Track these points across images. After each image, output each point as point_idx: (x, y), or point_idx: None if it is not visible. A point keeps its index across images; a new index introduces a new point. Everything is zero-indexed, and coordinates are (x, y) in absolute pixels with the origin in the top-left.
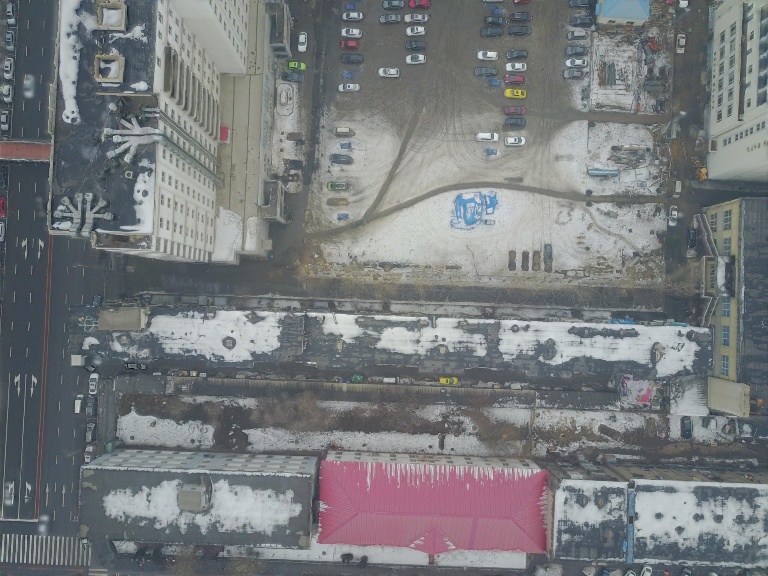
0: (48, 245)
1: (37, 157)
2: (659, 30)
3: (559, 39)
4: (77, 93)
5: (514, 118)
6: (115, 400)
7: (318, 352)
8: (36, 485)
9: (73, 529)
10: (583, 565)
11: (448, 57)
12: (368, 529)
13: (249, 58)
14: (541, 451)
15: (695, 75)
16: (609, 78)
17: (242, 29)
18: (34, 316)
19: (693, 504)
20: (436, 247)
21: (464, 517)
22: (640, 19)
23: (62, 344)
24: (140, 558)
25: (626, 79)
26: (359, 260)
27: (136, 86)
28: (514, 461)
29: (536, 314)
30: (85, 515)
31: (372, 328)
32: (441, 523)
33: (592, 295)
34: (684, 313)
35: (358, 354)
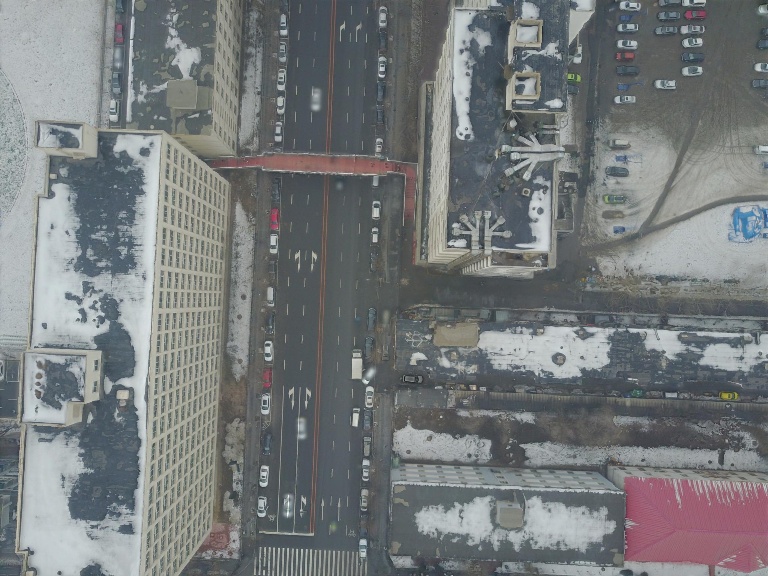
0: (321, 257)
1: (322, 169)
2: None
3: None
4: (470, 109)
5: None
6: (391, 414)
7: (640, 368)
8: (311, 499)
9: (349, 543)
10: None
11: (724, 69)
12: (680, 547)
13: None
14: None
15: None
16: None
17: None
18: (307, 329)
19: None
20: (713, 261)
21: None
22: None
23: (336, 357)
24: (418, 573)
25: None
26: (635, 273)
27: (551, 103)
28: None
29: None
30: (396, 531)
31: (695, 344)
32: (757, 541)
33: None
34: None
35: (681, 370)
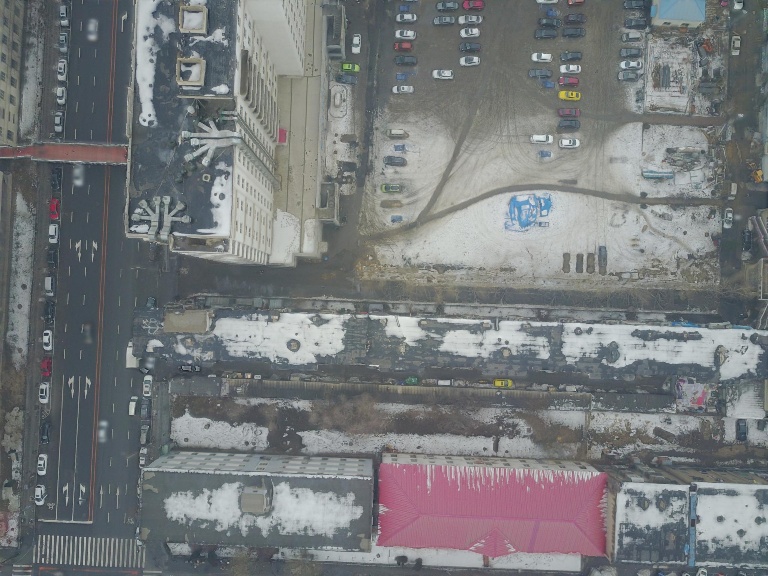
0: (102, 247)
1: (93, 159)
2: (714, 32)
3: (613, 41)
4: (154, 96)
5: (568, 120)
6: (169, 402)
7: (381, 355)
8: (90, 487)
9: (127, 531)
10: (638, 568)
11: (502, 59)
12: (429, 532)
13: (306, 60)
14: (596, 454)
15: (750, 77)
16: (663, 80)
17: (301, 31)
18: (88, 318)
19: (755, 507)
20: (490, 249)
21: (526, 520)
22: (696, 21)
23: (116, 346)
24: (195, 560)
25: (681, 81)
26: (413, 262)
27: (217, 89)
28: (570, 464)
29: (591, 316)
30: (146, 517)
31: (435, 331)
32: (502, 526)
33: (646, 297)
34: (739, 315)
35: (421, 357)
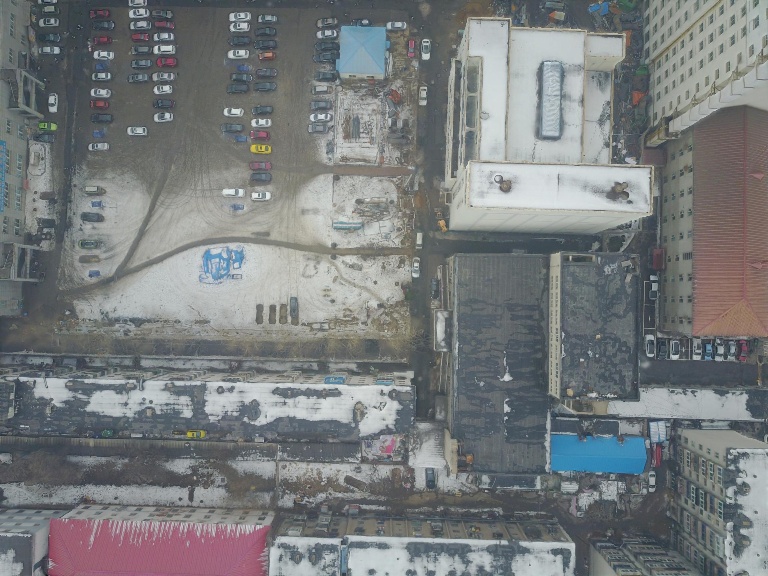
0: None
1: None
2: (403, 83)
3: (304, 94)
4: None
5: (259, 173)
6: None
7: (30, 416)
8: None
9: None
10: None
11: (196, 114)
12: None
13: None
14: (288, 502)
15: (439, 126)
16: (353, 131)
17: None
18: None
19: (406, 560)
20: (185, 302)
21: (178, 575)
22: (376, 74)
23: None
24: None
25: (370, 132)
26: (110, 316)
27: None
28: (255, 514)
29: (282, 367)
30: None
31: (82, 391)
32: None
33: (338, 347)
34: (428, 364)
35: (68, 417)
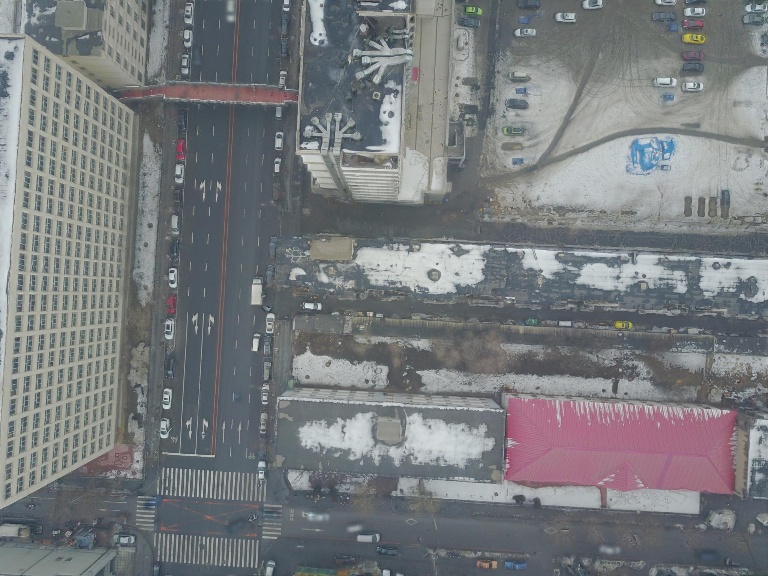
0: (225, 187)
1: (223, 98)
2: None
3: None
4: (324, 15)
5: (692, 63)
6: (291, 340)
7: (518, 287)
8: (213, 422)
9: (249, 465)
10: (757, 512)
11: (625, 2)
12: (559, 465)
13: None
14: (716, 397)
15: None
16: None
17: None
18: (211, 257)
19: None
20: (611, 192)
21: (659, 454)
22: None
23: (239, 284)
24: (315, 495)
25: None
26: (533, 205)
27: (394, 5)
28: (693, 405)
29: None
30: (281, 445)
31: (572, 264)
32: (634, 460)
33: None
34: None
35: (557, 289)
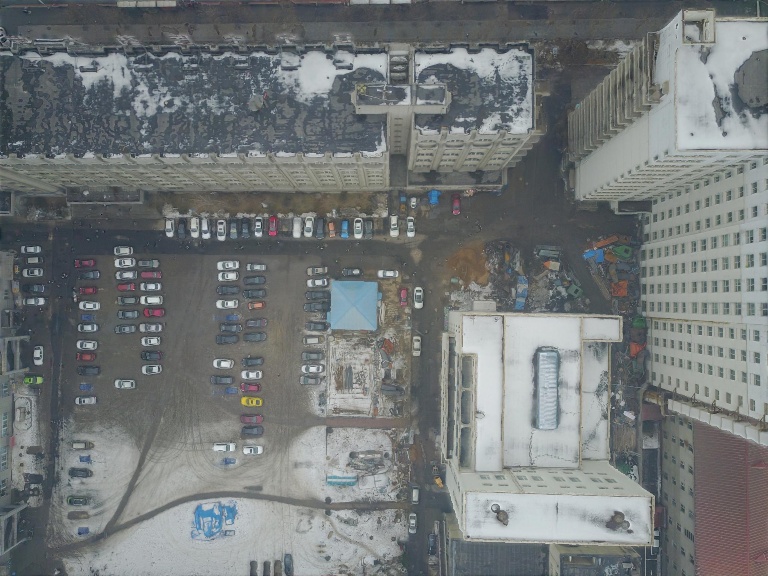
0: None
1: None
2: (396, 331)
3: (295, 343)
4: None
5: (250, 427)
6: None
7: None
8: None
9: None
10: None
11: (185, 365)
12: None
13: None
14: None
15: (433, 376)
16: (346, 382)
17: None
18: None
19: None
20: (177, 559)
21: None
22: (369, 329)
23: None
24: None
25: (363, 383)
26: (101, 574)
27: None
28: None
29: None
30: None
31: None
32: None
33: None
34: None
35: None
